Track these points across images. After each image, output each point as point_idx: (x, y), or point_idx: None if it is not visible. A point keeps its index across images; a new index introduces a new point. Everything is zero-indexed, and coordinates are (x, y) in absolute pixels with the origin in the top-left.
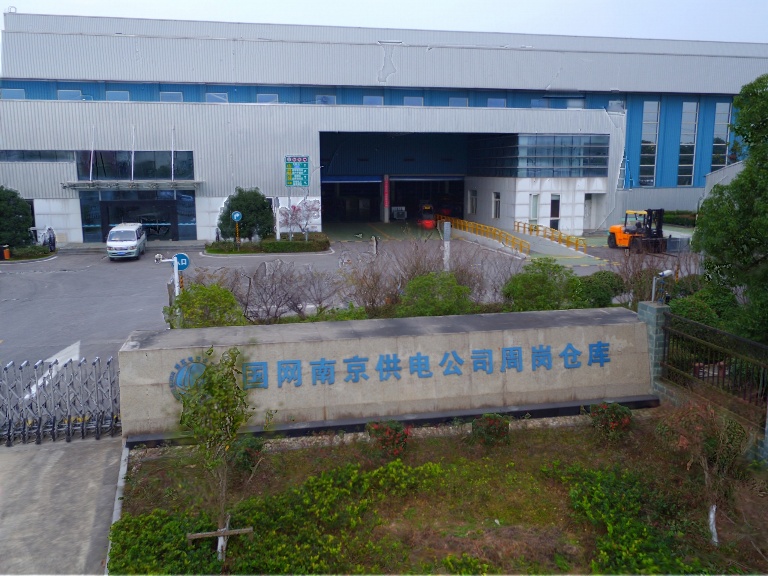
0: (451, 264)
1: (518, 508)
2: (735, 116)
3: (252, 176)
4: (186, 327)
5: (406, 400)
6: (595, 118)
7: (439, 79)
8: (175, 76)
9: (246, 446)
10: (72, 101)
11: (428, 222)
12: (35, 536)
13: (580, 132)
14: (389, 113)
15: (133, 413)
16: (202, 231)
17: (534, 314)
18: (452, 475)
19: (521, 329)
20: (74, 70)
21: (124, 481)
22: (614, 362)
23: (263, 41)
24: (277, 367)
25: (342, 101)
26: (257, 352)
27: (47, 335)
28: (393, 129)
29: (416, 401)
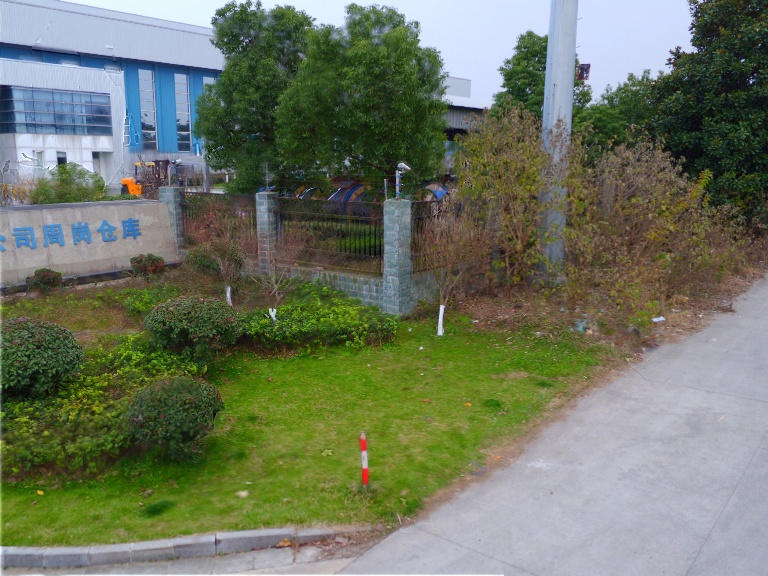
0: None
1: (83, 322)
2: (213, 33)
3: None
4: None
5: None
6: (93, 77)
7: None
8: None
9: None
10: None
11: None
12: None
13: (79, 90)
14: None
15: None
16: None
17: (67, 204)
18: (16, 310)
19: (59, 208)
20: None
21: None
22: (145, 235)
23: None
24: None
25: None
26: None
27: None
28: None
29: None
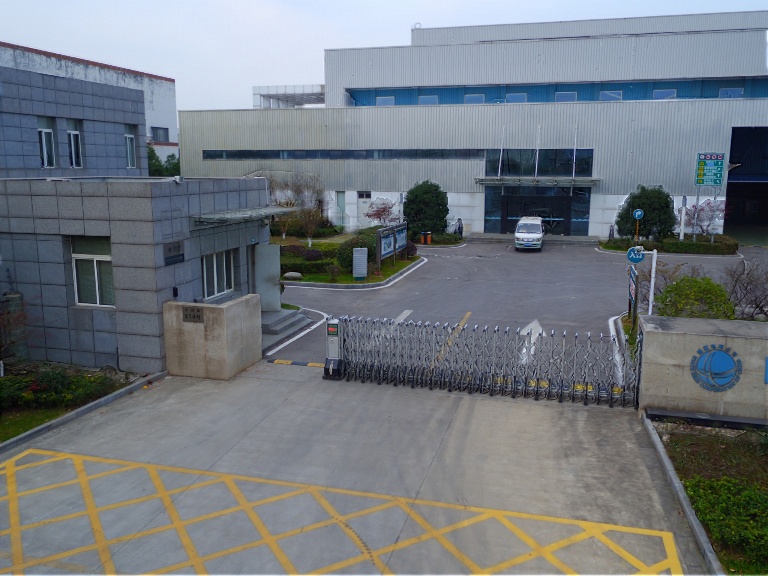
0: None
1: None
2: None
3: (651, 174)
4: (679, 316)
5: None
6: None
7: None
8: (573, 76)
9: None
10: (488, 104)
11: None
12: (604, 477)
13: None
14: None
15: (653, 388)
16: (594, 227)
17: None
18: None
19: None
20: (482, 76)
21: (664, 447)
22: None
23: (667, 35)
24: None
25: (750, 93)
26: None
27: (505, 311)
28: None
29: None
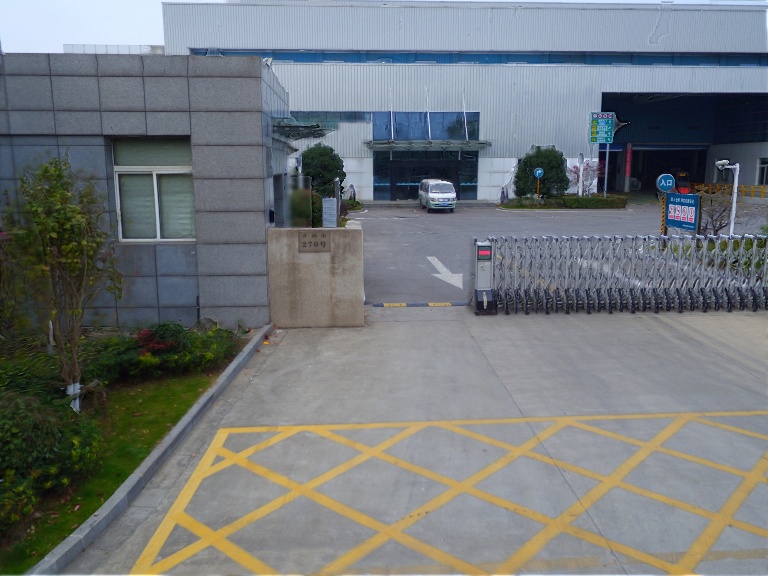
0: None
1: None
2: None
3: (533, 137)
4: None
5: None
6: None
7: (694, 43)
8: (434, 45)
9: None
10: (373, 64)
11: (684, 189)
12: None
13: None
14: (673, 73)
15: None
16: (482, 191)
17: None
18: None
19: None
20: (342, 41)
21: None
22: None
23: (520, 8)
24: None
25: None
26: None
27: None
28: (676, 89)
29: None
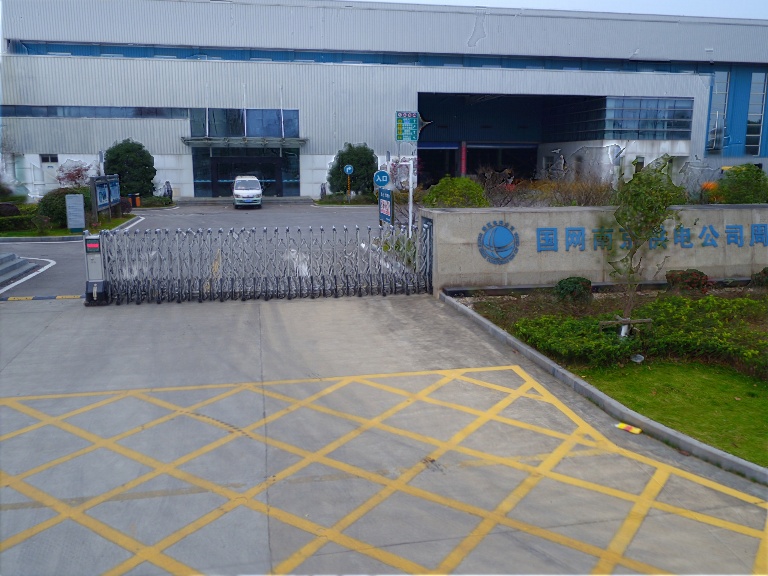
0: (620, 187)
1: None
2: None
3: (353, 135)
4: None
5: (671, 267)
6: (681, 82)
7: (518, 47)
8: (267, 42)
9: (581, 281)
10: (188, 60)
11: None
12: (436, 340)
13: (666, 95)
14: (484, 75)
15: (448, 268)
16: (305, 188)
17: None
18: (765, 305)
19: (767, 208)
20: (172, 36)
21: (474, 311)
22: None
23: (351, 9)
24: (565, 233)
25: None
26: (549, 219)
27: None
28: (487, 91)
29: (679, 268)
